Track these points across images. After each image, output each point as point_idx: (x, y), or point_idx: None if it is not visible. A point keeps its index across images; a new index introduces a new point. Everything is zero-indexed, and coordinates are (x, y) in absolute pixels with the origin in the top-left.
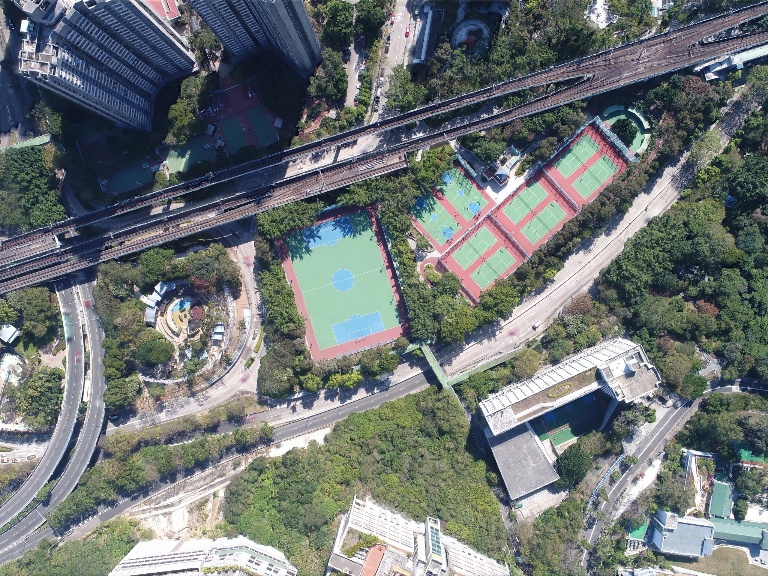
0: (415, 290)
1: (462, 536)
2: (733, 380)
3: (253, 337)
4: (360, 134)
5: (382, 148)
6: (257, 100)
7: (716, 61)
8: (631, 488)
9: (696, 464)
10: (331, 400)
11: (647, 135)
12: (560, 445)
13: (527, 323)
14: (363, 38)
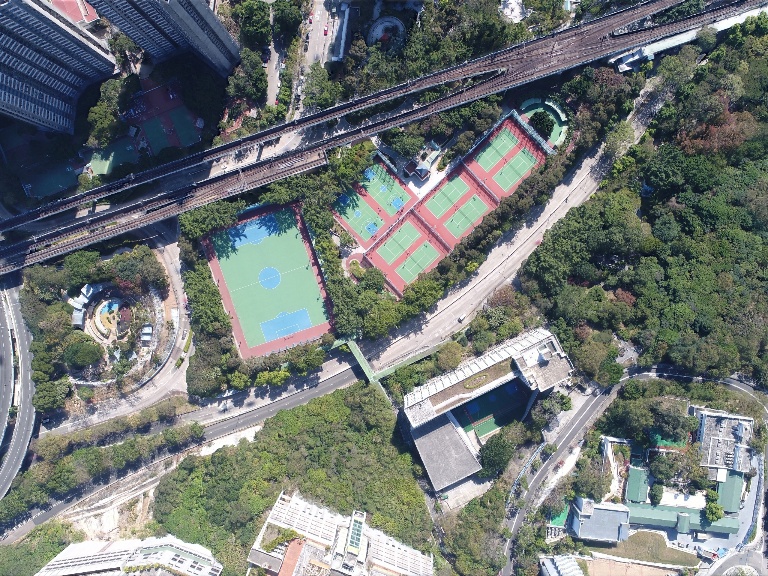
0: (339, 286)
1: (387, 528)
2: (650, 367)
3: (182, 337)
4: (279, 132)
5: None
6: (178, 101)
7: (630, 53)
8: (552, 476)
9: (612, 450)
10: (261, 398)
11: (564, 127)
12: (484, 436)
13: (453, 316)
14: (282, 37)
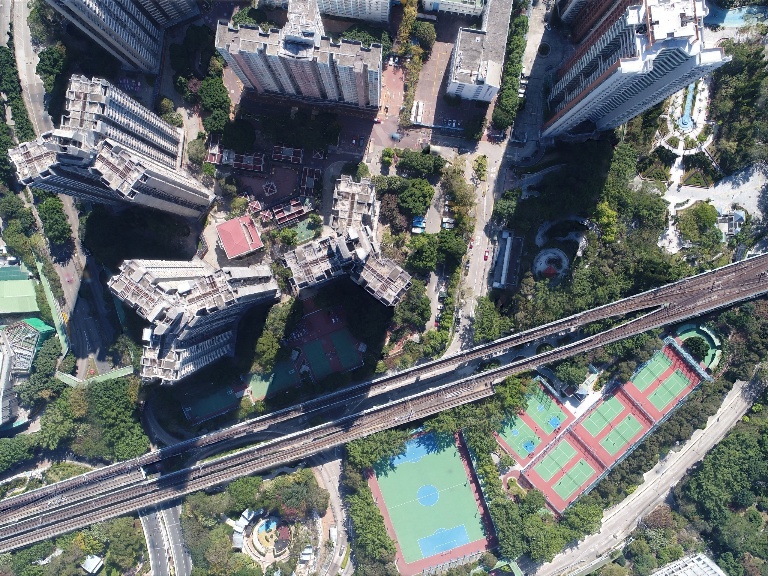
0: (502, 510)
1: None
2: None
3: (339, 553)
4: (447, 363)
5: (464, 367)
6: (340, 324)
7: None
8: None
9: None
10: None
11: (718, 352)
12: None
13: (608, 531)
14: None
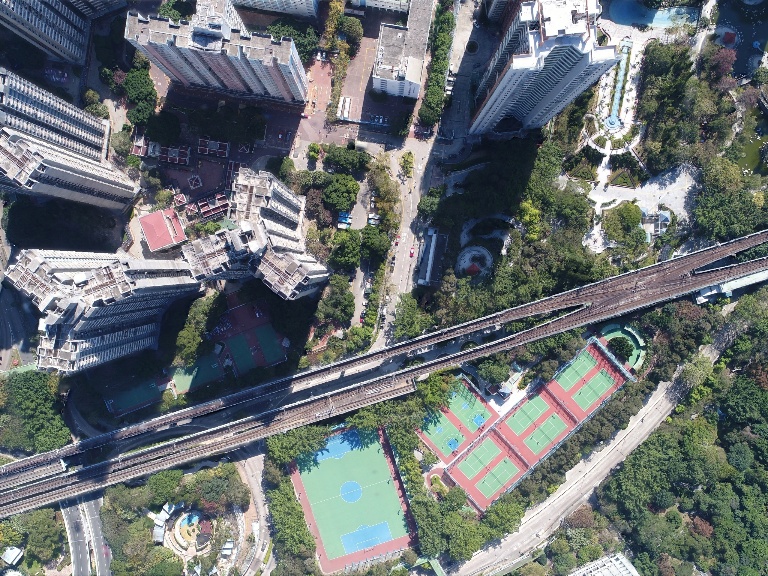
0: (423, 507)
1: None
2: None
3: (262, 548)
4: (368, 359)
5: (388, 364)
6: (264, 319)
7: None
8: None
9: None
10: None
11: (642, 352)
12: None
13: (531, 530)
14: None
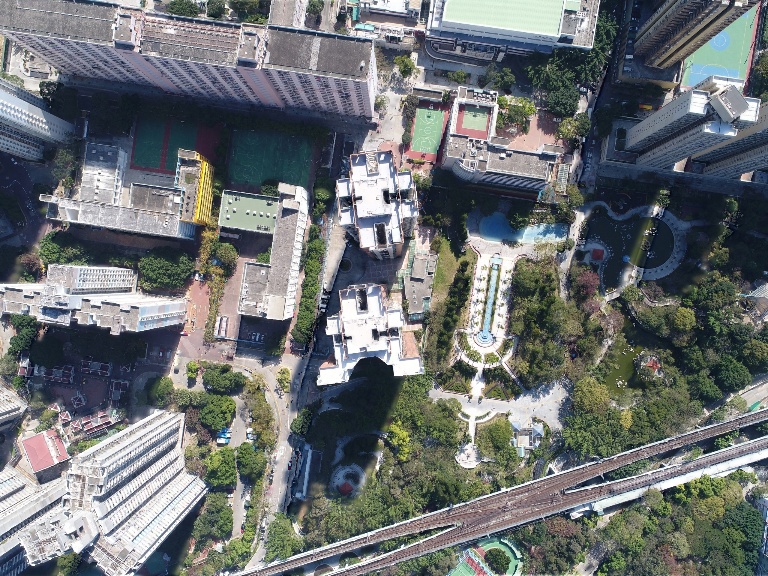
0: None
1: None
2: None
3: None
4: None
5: None
6: None
7: None
8: None
9: None
10: None
11: (520, 564)
12: None
13: None
14: None
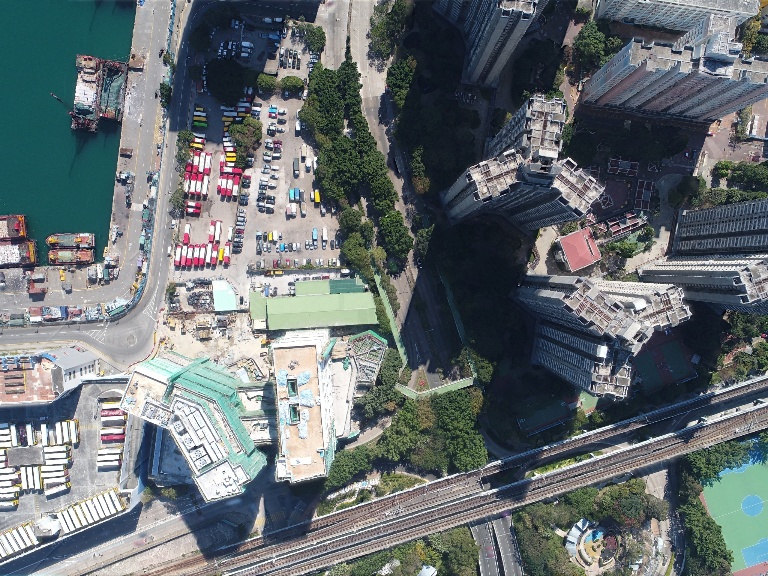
0: None
1: None
2: None
3: (663, 563)
4: None
5: None
6: (672, 336)
7: None
8: None
9: None
10: None
11: None
12: None
13: None
14: None
